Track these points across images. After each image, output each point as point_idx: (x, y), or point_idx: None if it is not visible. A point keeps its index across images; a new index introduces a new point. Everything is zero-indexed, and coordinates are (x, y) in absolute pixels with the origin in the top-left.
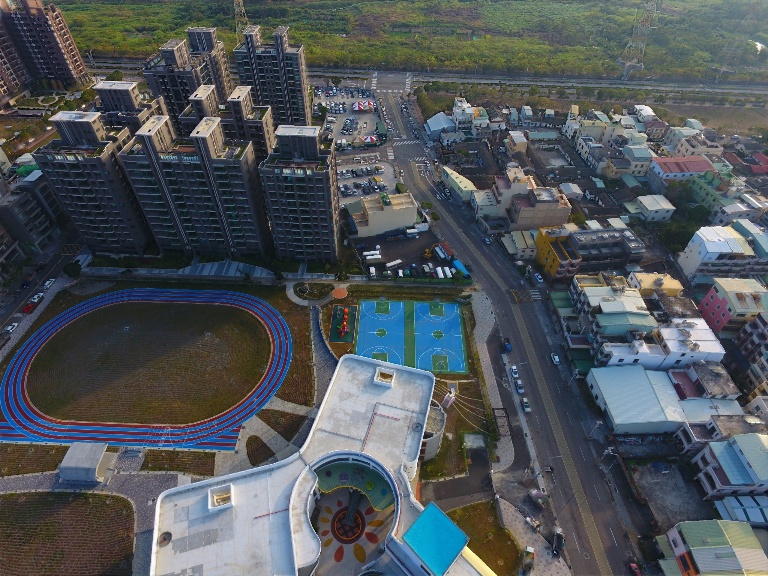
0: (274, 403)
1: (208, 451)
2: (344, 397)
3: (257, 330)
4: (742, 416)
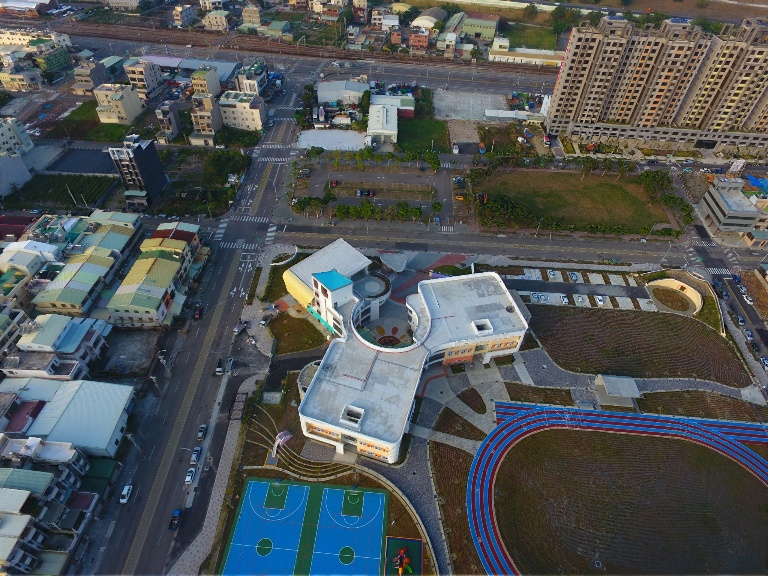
0: (471, 446)
1: (518, 402)
2: (395, 399)
3: (530, 567)
4: (16, 368)
